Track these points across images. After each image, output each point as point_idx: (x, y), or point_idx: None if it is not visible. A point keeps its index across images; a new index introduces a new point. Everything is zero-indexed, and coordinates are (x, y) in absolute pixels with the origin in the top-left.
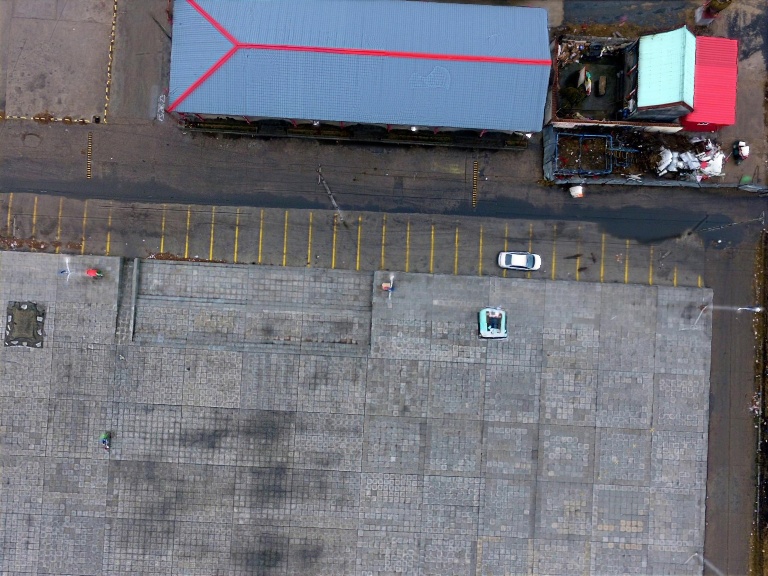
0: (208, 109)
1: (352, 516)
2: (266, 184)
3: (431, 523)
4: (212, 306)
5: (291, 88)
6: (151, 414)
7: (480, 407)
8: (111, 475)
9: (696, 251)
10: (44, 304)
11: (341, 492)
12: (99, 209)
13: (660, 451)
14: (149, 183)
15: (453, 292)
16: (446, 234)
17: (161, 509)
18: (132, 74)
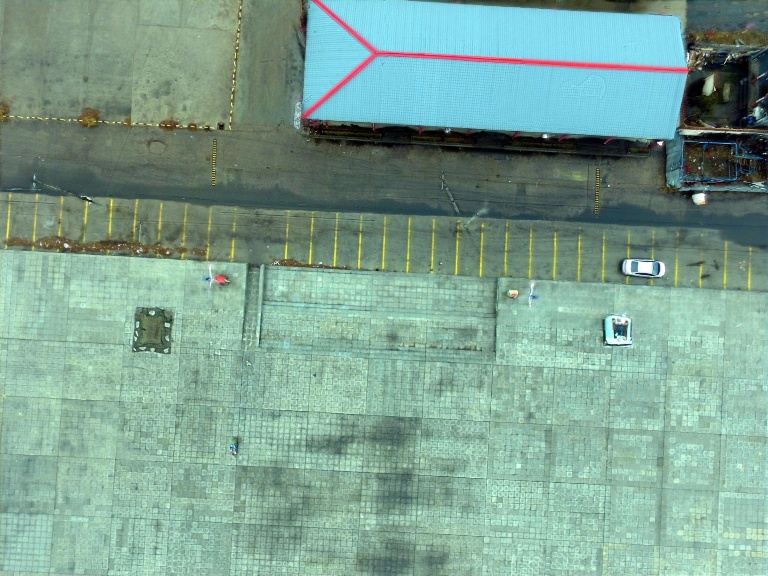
0: (342, 116)
1: (478, 523)
2: (389, 191)
3: (557, 530)
4: (337, 312)
5: (426, 96)
6: (278, 420)
7: (605, 414)
8: (238, 481)
9: None
10: (171, 310)
11: (467, 499)
12: (224, 215)
13: None
14: (273, 190)
15: (578, 299)
16: (569, 241)
17: (288, 515)
18: (256, 81)
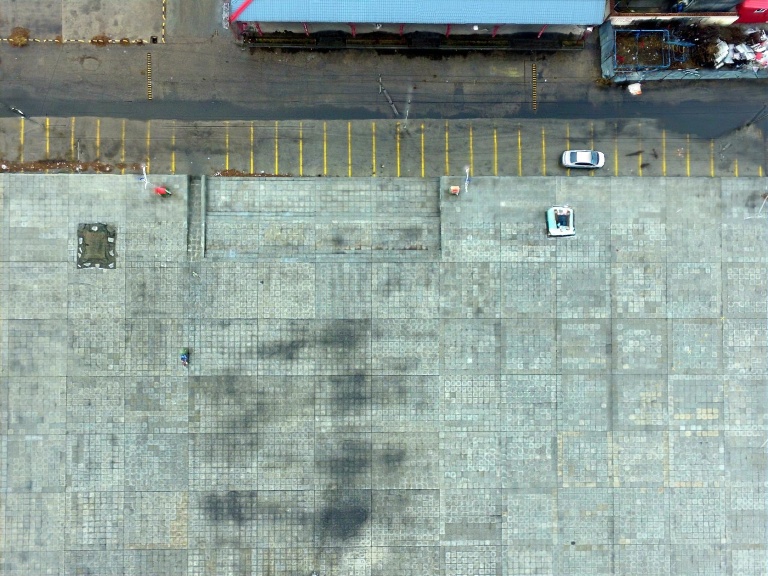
0: (271, 17)
1: (432, 419)
2: (327, 96)
3: (511, 421)
4: (281, 219)
5: None
6: (227, 329)
7: (552, 305)
8: (191, 391)
9: (756, 142)
10: (114, 225)
11: (420, 396)
12: (162, 129)
13: (731, 339)
14: (211, 101)
15: (520, 193)
16: (509, 137)
17: (243, 422)
18: None
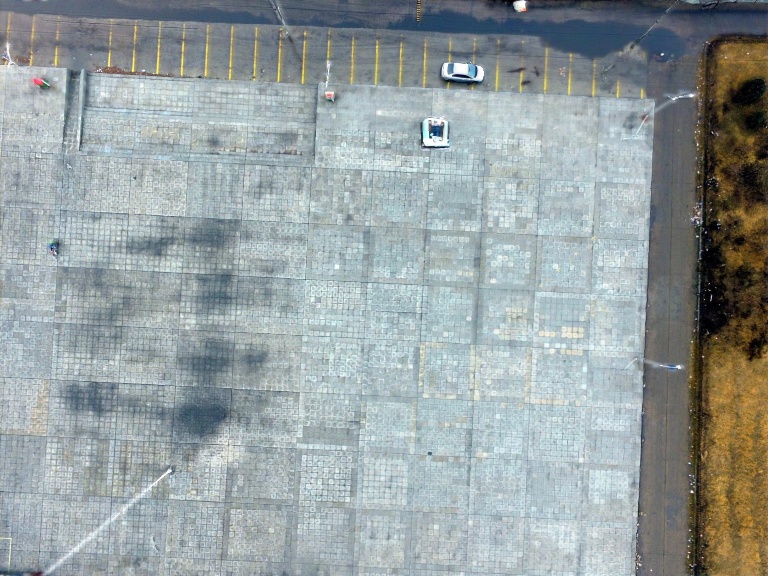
0: None
1: (296, 322)
2: None
3: (374, 329)
4: (158, 118)
5: None
6: (98, 222)
7: (423, 216)
8: (59, 281)
9: (639, 64)
10: None
11: (286, 299)
12: (47, 24)
13: (601, 259)
14: None
15: (396, 103)
16: (390, 48)
17: (108, 315)
18: None
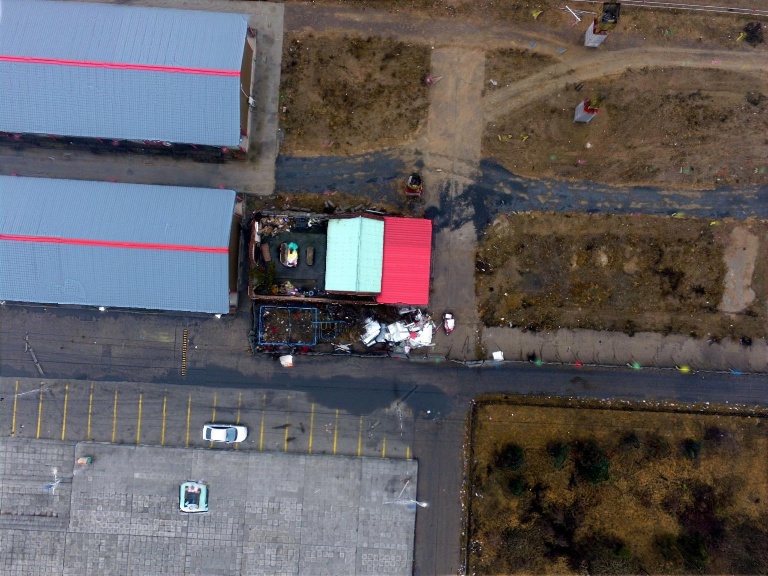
0: None
1: None
2: None
3: None
4: None
5: None
6: None
7: None
8: None
9: (405, 421)
10: None
11: None
12: None
13: None
14: None
15: (155, 465)
16: (154, 403)
17: None
18: None
